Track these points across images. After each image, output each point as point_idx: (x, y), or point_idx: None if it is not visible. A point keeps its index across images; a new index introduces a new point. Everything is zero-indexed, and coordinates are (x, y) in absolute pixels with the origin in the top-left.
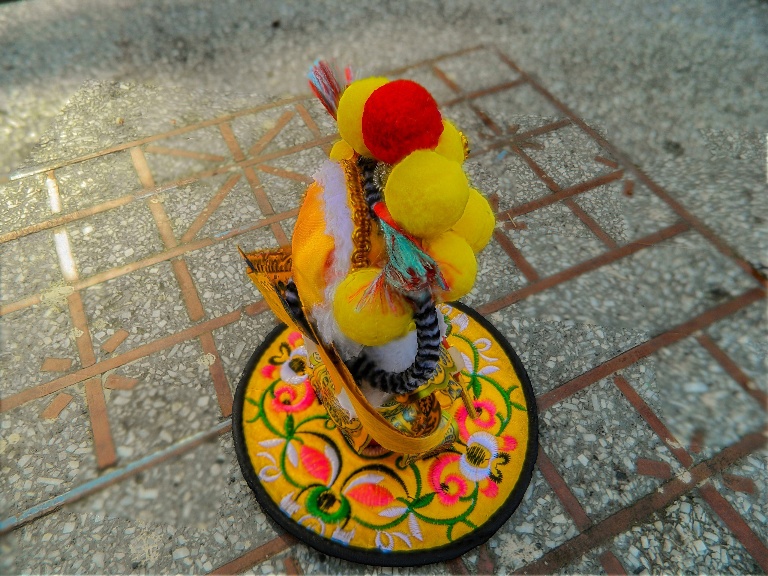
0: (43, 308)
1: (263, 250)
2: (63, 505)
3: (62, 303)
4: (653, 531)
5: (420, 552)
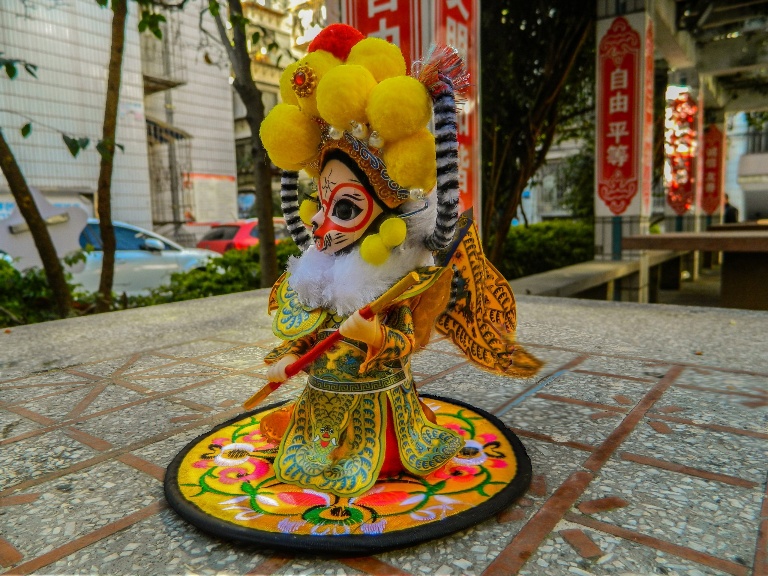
0: (766, 425)
1: (686, 530)
2: (536, 383)
3: (761, 431)
4: (46, 469)
5: (274, 407)
